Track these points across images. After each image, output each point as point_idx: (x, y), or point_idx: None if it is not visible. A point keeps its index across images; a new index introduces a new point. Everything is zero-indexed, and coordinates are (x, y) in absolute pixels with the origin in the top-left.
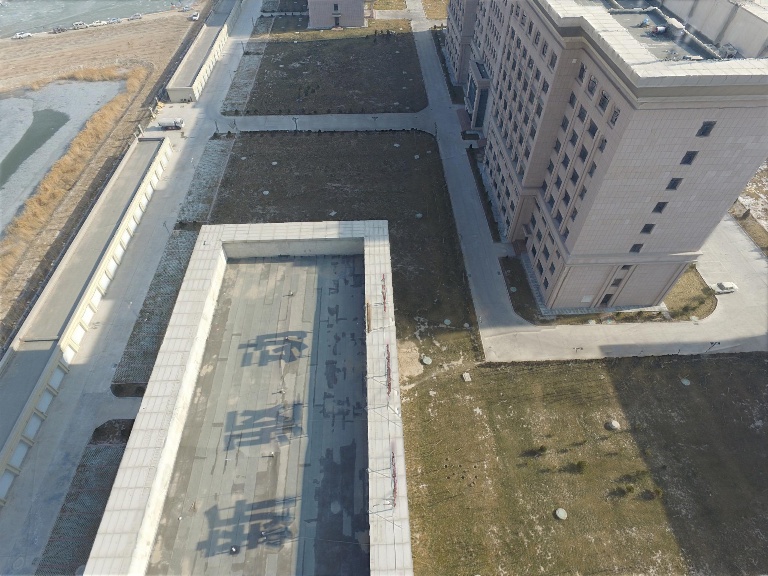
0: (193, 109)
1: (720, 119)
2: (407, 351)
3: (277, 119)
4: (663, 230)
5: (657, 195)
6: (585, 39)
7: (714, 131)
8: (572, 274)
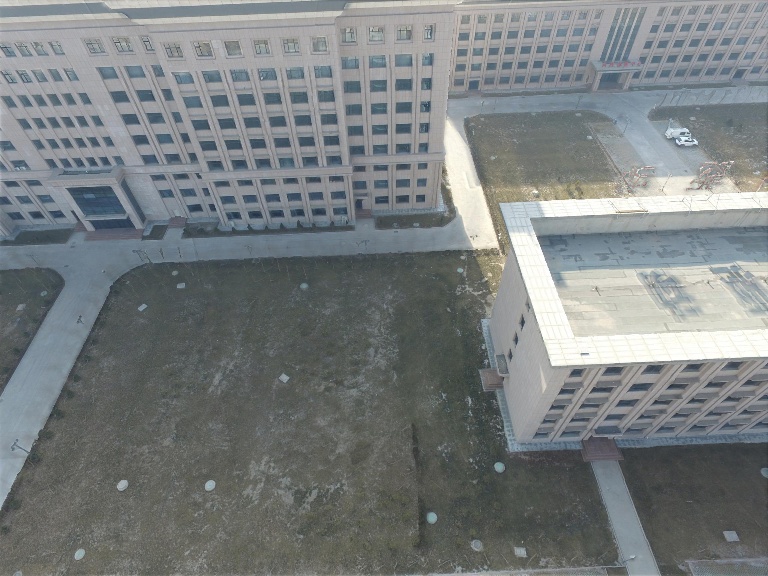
0: None
1: None
2: None
3: None
4: None
5: None
6: (349, 3)
7: None
8: None
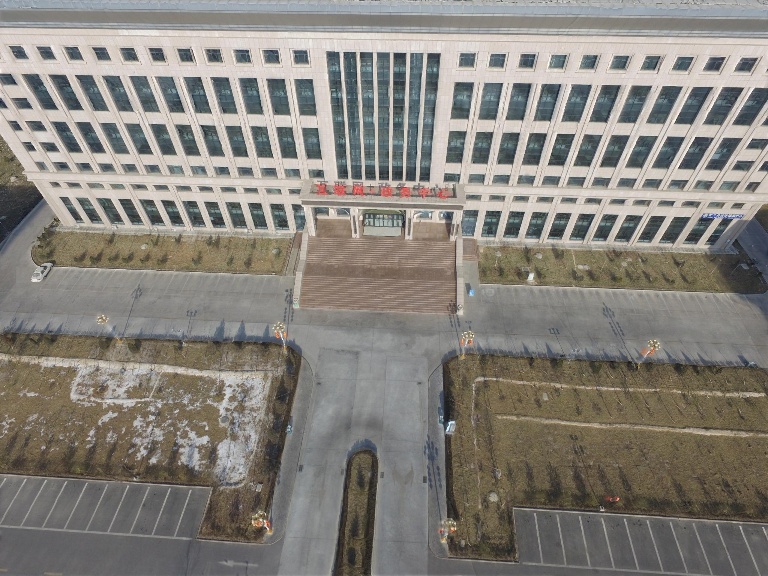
0: None
1: None
2: None
3: None
4: None
5: None
6: None
7: None
8: None
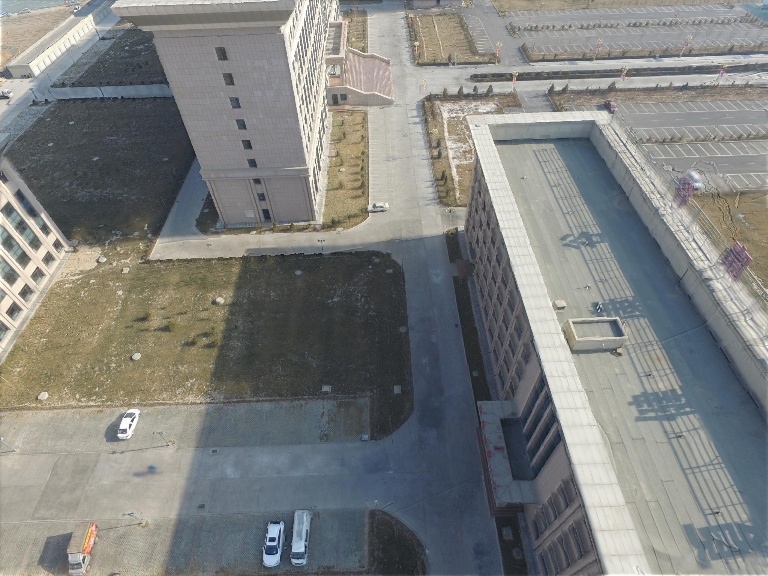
0: (29, 83)
1: (225, 45)
2: (90, 253)
3: (95, 89)
4: (261, 146)
5: (229, 113)
6: None
7: (229, 56)
8: (218, 189)
